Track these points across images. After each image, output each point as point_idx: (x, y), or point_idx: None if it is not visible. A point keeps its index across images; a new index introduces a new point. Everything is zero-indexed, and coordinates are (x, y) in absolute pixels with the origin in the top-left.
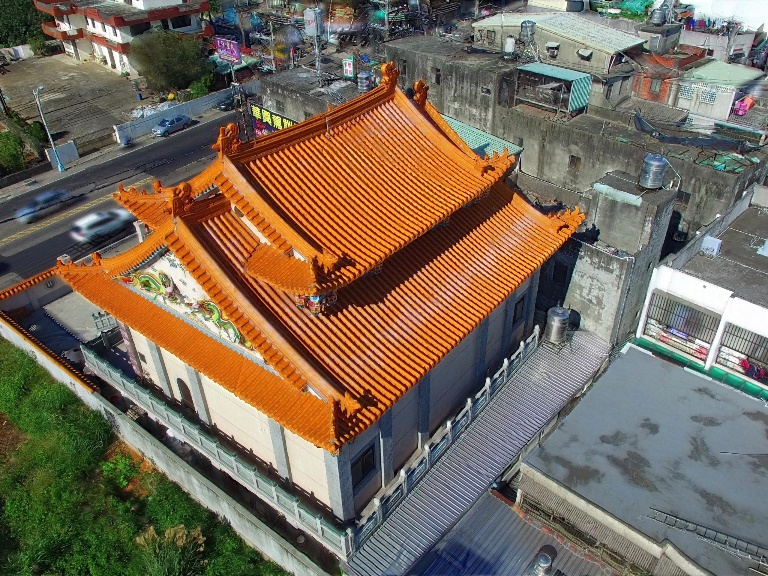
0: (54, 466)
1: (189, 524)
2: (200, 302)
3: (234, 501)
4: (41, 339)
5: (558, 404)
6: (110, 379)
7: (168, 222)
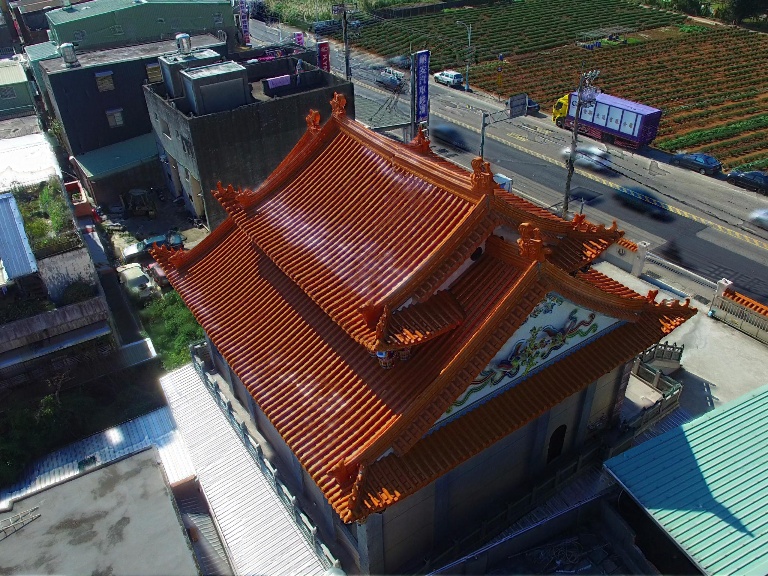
0: None
1: None
2: None
3: None
4: None
5: (247, 575)
6: None
7: None
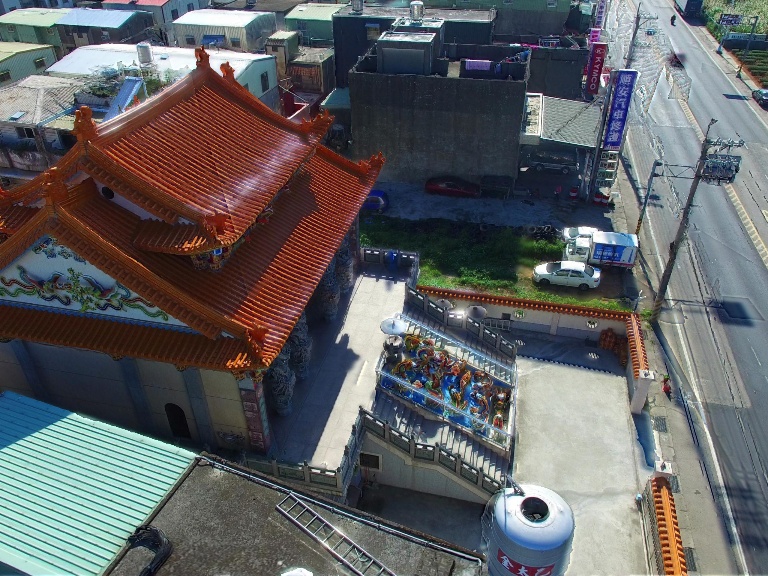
0: None
1: None
2: None
3: None
4: (566, 348)
5: None
6: None
7: None
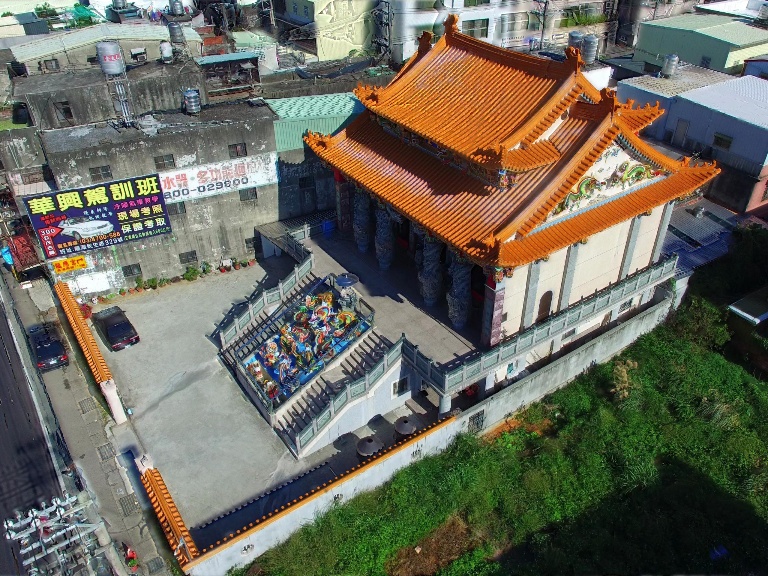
0: (514, 479)
1: (589, 390)
2: (620, 171)
3: (604, 335)
4: None
5: None
6: (483, 372)
7: (607, 122)
